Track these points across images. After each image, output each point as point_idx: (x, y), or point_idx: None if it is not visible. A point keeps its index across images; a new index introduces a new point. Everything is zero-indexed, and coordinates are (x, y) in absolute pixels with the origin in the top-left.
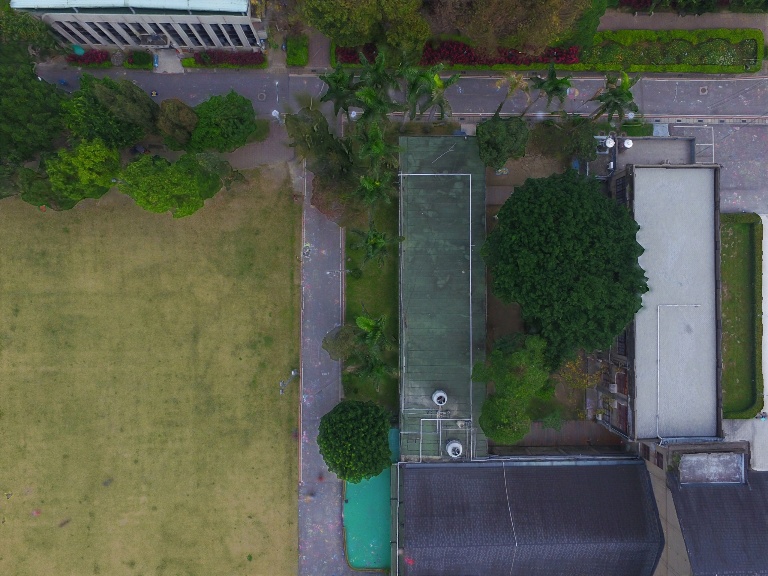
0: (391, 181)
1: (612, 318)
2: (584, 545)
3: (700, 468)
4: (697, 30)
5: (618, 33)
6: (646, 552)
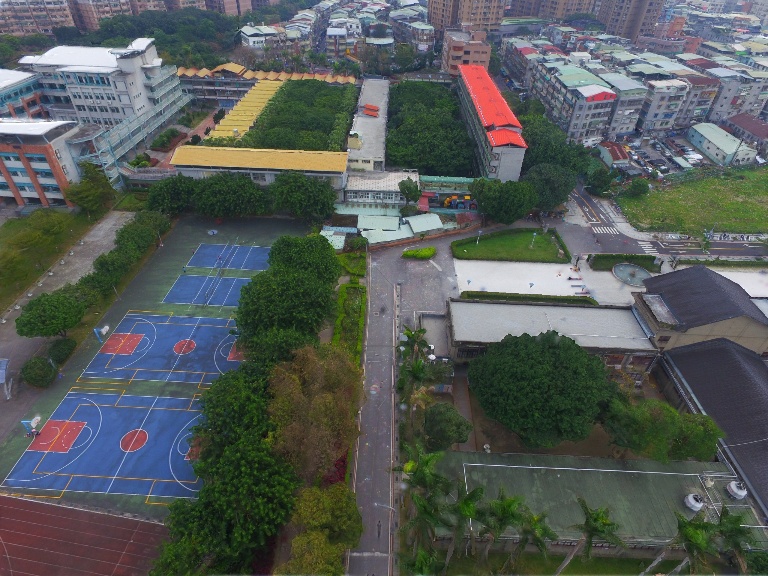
0: (466, 559)
1: None
2: (760, 385)
3: (663, 315)
4: None
5: None
6: (736, 350)
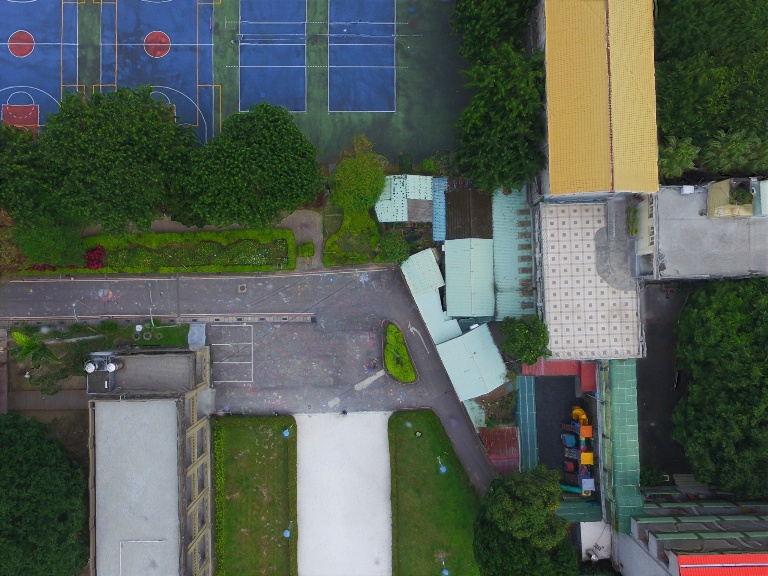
0: None
1: (39, 569)
2: None
3: None
4: (224, 232)
5: (143, 237)
6: None
